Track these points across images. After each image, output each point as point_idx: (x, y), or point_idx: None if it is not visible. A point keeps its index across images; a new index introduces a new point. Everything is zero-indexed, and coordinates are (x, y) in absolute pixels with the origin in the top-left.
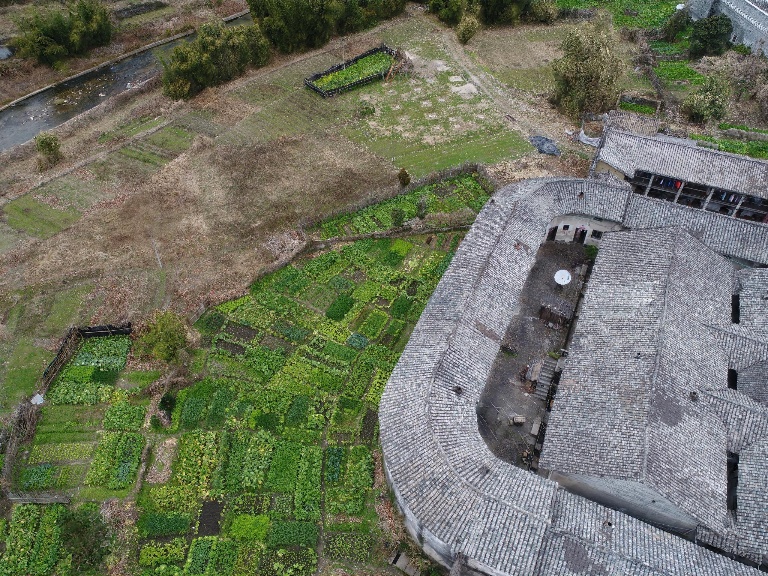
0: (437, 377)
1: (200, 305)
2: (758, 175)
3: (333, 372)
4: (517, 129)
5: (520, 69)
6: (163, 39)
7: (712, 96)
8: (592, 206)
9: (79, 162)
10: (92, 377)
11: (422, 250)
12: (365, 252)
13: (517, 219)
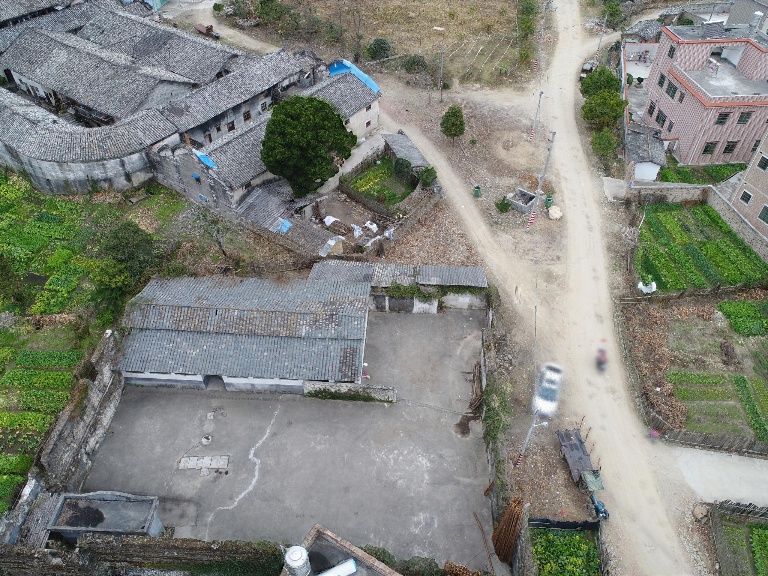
0: None
1: None
2: (21, 1)
3: None
4: None
5: None
6: None
7: None
8: None
9: None
10: None
11: None
12: None
13: None
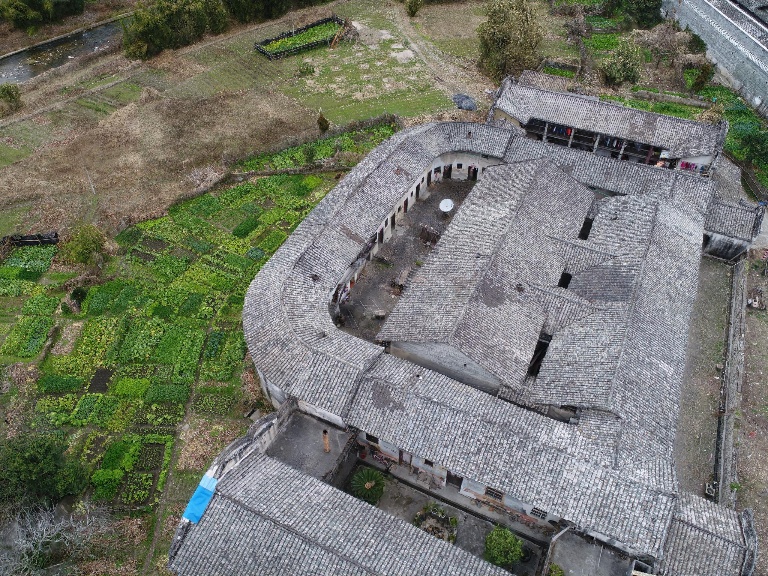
0: (297, 266)
1: (121, 221)
2: (638, 122)
3: (228, 276)
4: (443, 89)
5: (459, 39)
6: None
7: (623, 60)
8: (478, 144)
9: (38, 110)
10: (18, 275)
11: (330, 184)
12: (278, 185)
13: (404, 151)
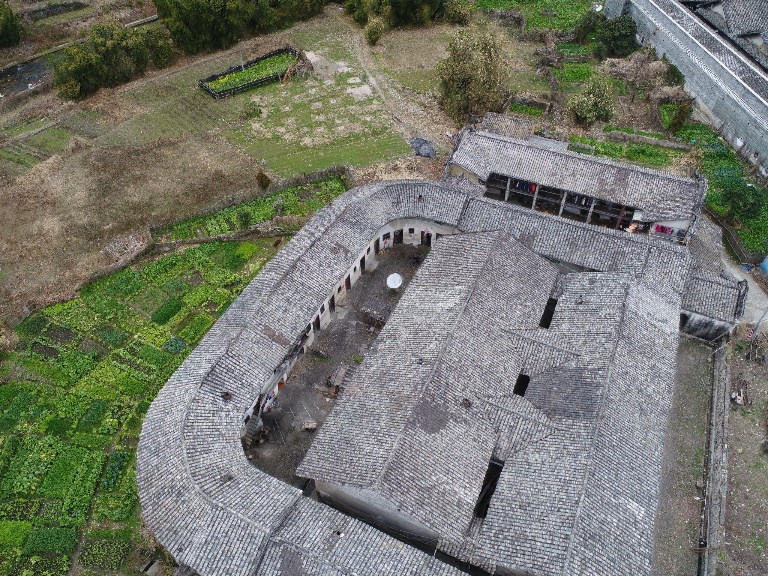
0: (205, 383)
1: (23, 308)
2: (608, 178)
3: (139, 376)
4: (400, 131)
5: (422, 70)
6: (77, 40)
7: (595, 98)
8: (430, 209)
9: None
10: None
11: (267, 253)
12: (209, 255)
13: (344, 222)
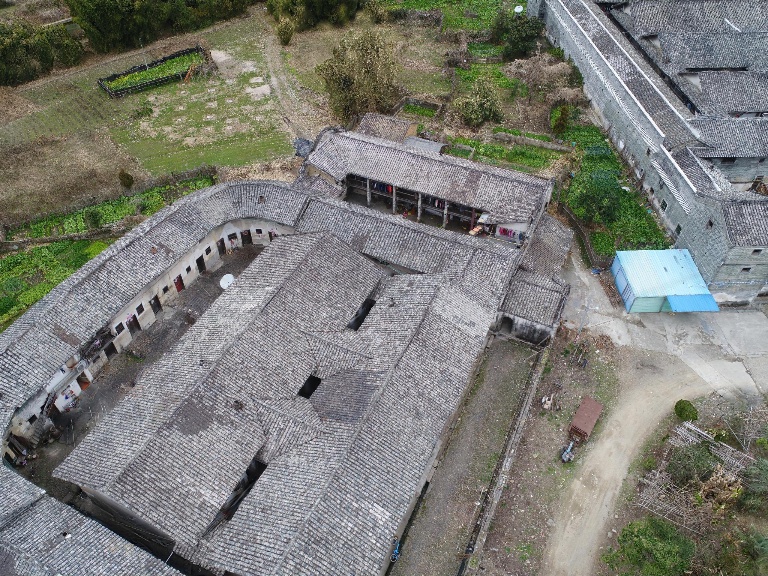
0: None
1: None
2: (460, 180)
3: None
4: (287, 131)
5: None
6: None
7: (480, 99)
8: (270, 210)
9: None
10: None
11: None
12: (56, 254)
13: (173, 222)
